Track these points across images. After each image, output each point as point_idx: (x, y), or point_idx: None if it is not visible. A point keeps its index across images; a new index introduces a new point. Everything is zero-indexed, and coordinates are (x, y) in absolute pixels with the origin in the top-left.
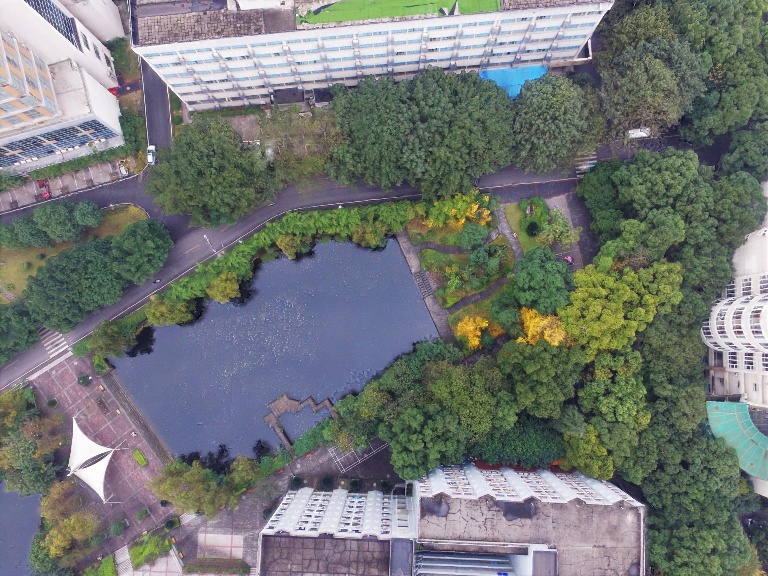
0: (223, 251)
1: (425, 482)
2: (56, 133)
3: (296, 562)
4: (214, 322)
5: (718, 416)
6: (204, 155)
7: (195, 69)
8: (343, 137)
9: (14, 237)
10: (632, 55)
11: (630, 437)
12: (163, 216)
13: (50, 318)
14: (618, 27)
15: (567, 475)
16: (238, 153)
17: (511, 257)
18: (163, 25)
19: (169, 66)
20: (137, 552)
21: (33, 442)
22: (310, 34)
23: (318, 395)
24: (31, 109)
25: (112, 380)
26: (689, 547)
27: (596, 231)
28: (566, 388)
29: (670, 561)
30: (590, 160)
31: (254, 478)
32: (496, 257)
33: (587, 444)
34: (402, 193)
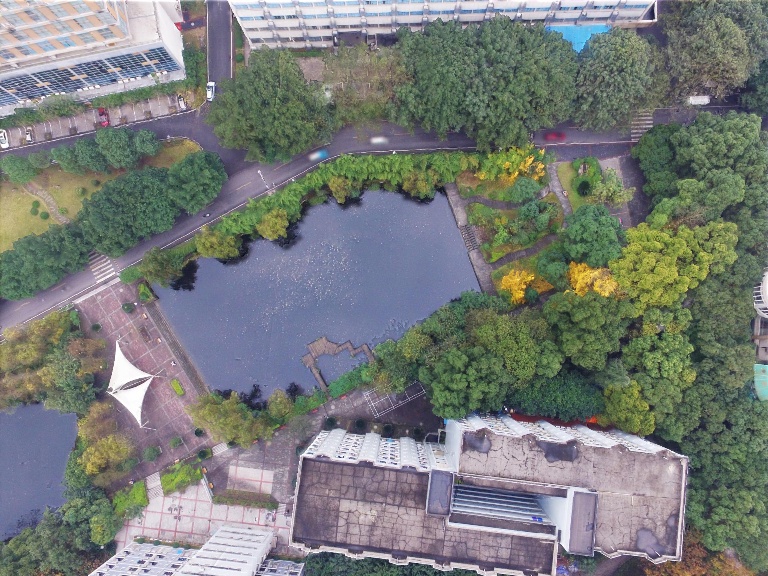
0: (274, 190)
1: (465, 423)
2: (122, 59)
3: (334, 487)
4: (259, 260)
5: (765, 379)
6: (270, 85)
7: (266, 0)
8: (407, 77)
9: (73, 159)
10: (702, 15)
11: (674, 393)
12: (217, 152)
13: (102, 241)
14: None
15: (604, 432)
16: (302, 86)
17: (560, 215)
18: None
19: None
20: (169, 478)
21: (77, 361)
22: None
23: (356, 340)
24: (106, 27)
25: (155, 309)
26: (728, 506)
27: (649, 193)
28: (612, 340)
29: (707, 519)
30: (646, 125)
31: (288, 415)
32: (546, 212)
33: (629, 398)
34: (455, 145)
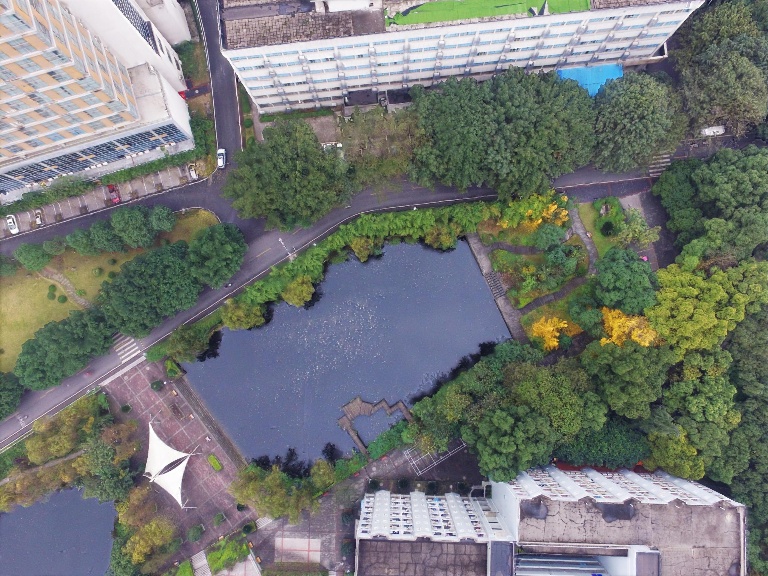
0: (295, 254)
1: (515, 484)
2: (131, 138)
3: (393, 566)
4: (285, 325)
5: None
6: (288, 158)
7: (277, 72)
8: (427, 139)
9: (89, 243)
10: (716, 53)
11: (722, 437)
12: (233, 220)
13: (126, 323)
14: (698, 25)
15: (651, 475)
16: (320, 156)
17: (585, 257)
18: (251, 28)
19: (252, 69)
20: (215, 557)
21: (111, 448)
22: (399, 35)
23: (391, 397)
24: (115, 114)
25: (184, 385)
26: None
27: (673, 230)
28: (655, 388)
29: (765, 560)
30: (663, 159)
31: None
32: (573, 257)
33: (677, 444)
34: (474, 194)
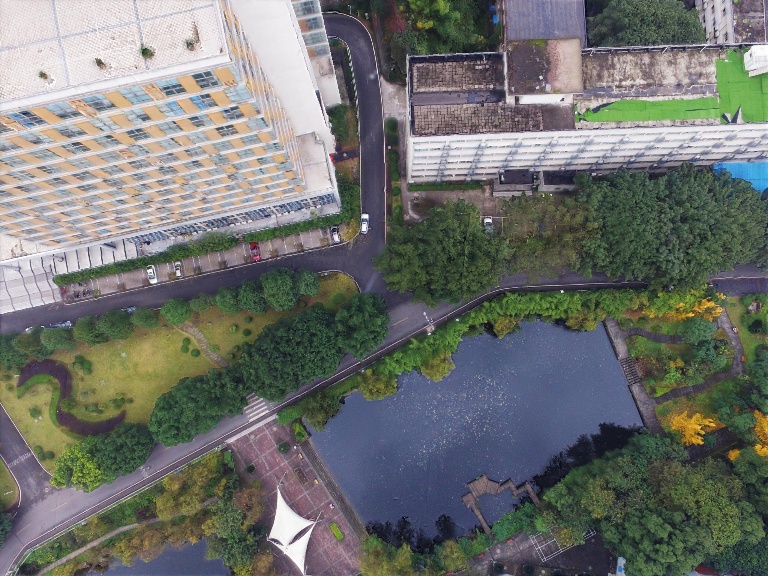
0: (432, 326)
1: None
2: None
3: None
4: (415, 395)
5: None
6: (457, 242)
7: (450, 154)
8: (596, 231)
9: (235, 303)
10: None
11: None
12: (372, 286)
13: (265, 387)
14: None
15: None
16: (486, 240)
17: None
18: (440, 115)
19: (427, 150)
20: None
21: (241, 512)
22: (589, 133)
23: (518, 478)
24: (290, 187)
25: (310, 448)
26: None
27: None
28: None
29: None
30: None
31: None
32: (722, 354)
33: None
34: (620, 279)
